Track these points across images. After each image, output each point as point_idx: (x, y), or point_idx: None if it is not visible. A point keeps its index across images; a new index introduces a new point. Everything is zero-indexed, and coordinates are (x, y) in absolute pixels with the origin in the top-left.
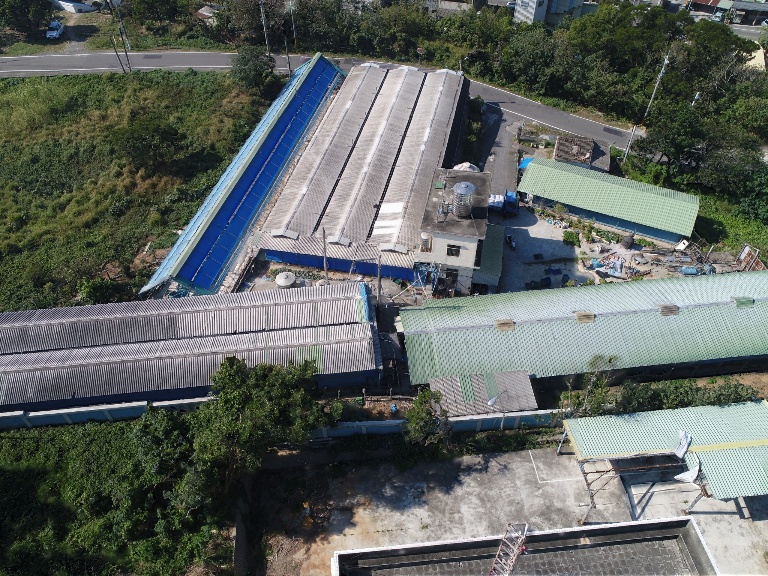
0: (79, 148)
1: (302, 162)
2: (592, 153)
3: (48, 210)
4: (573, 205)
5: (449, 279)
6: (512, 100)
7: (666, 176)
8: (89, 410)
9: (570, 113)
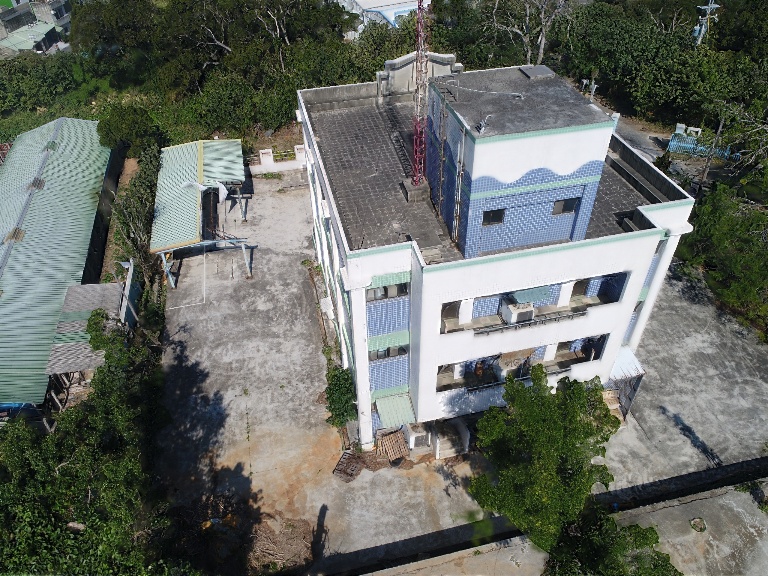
0: None
1: None
2: None
3: None
4: None
5: None
6: None
7: None
8: None
9: None
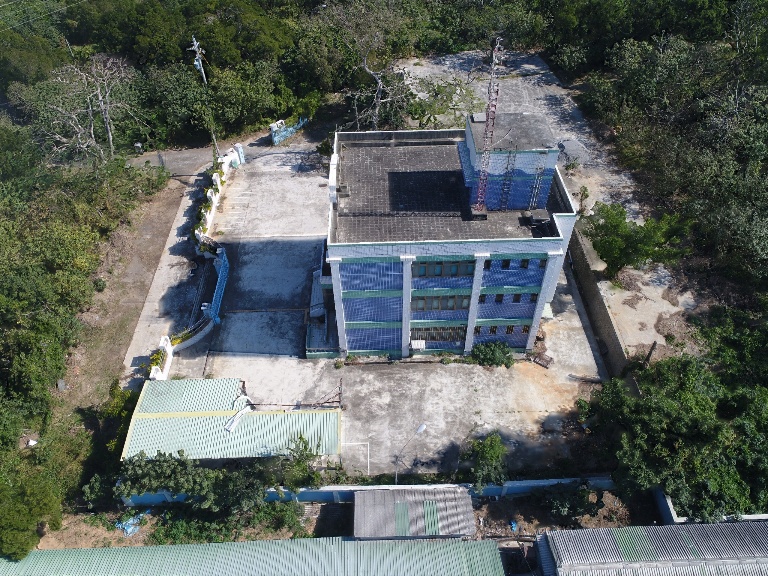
0: None
1: None
2: None
3: None
4: None
5: None
6: None
7: None
8: None
9: None
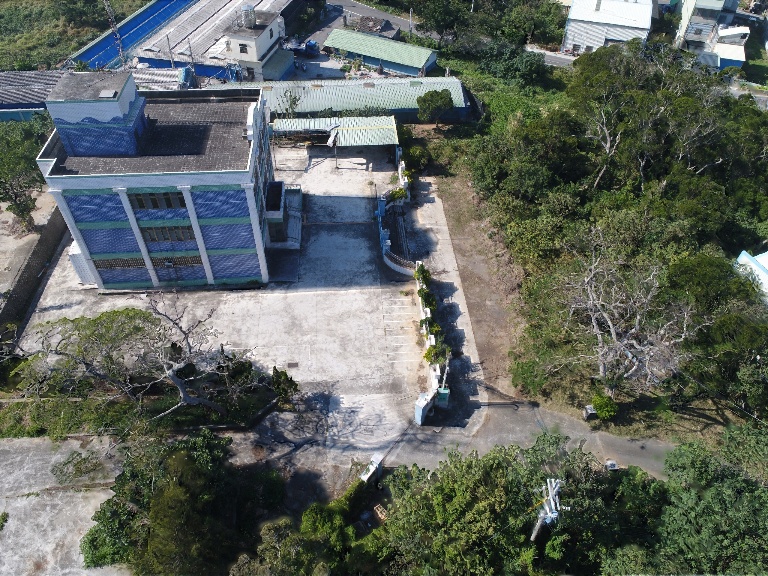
0: (32, 12)
1: (177, 19)
2: (383, 27)
3: (5, 41)
4: (355, 52)
5: (250, 76)
6: (354, 5)
7: (438, 48)
8: (10, 111)
9: (394, 15)
